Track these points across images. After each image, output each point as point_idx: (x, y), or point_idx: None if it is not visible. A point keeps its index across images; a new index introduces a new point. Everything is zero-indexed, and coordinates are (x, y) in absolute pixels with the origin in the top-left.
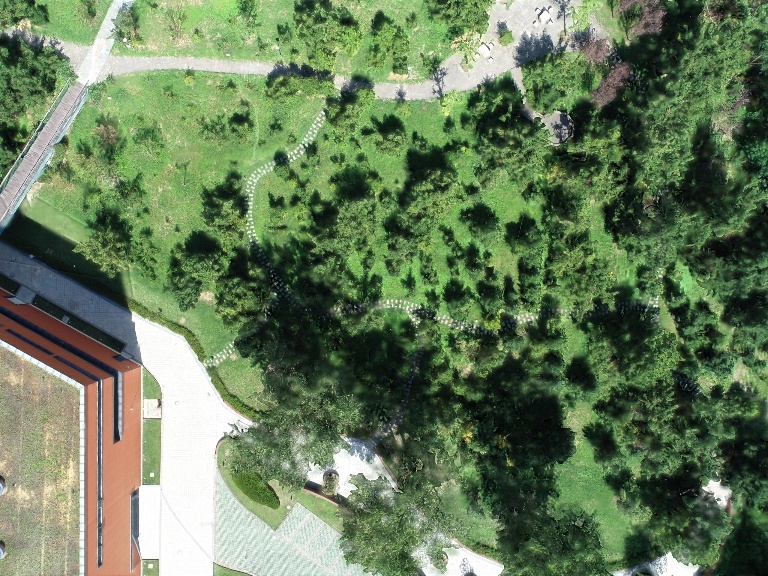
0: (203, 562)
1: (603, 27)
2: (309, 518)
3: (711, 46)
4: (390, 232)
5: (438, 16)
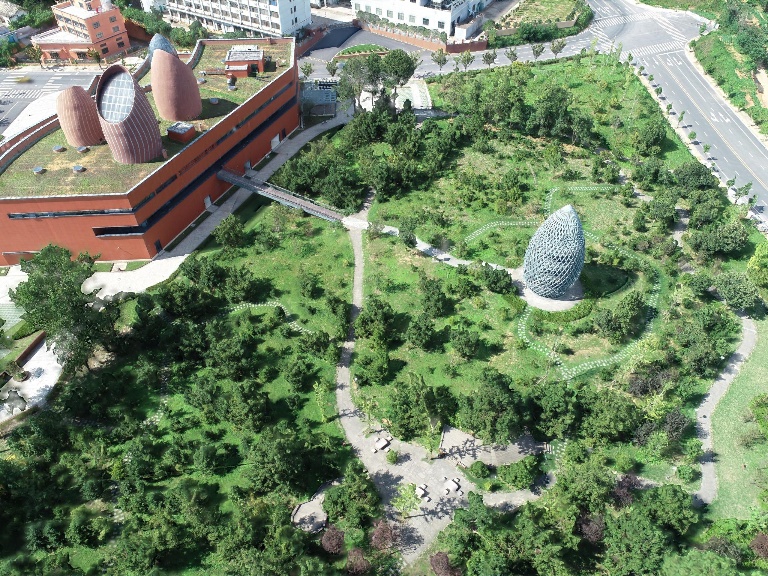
0: None
1: (419, 559)
2: None
3: None
4: None
5: None
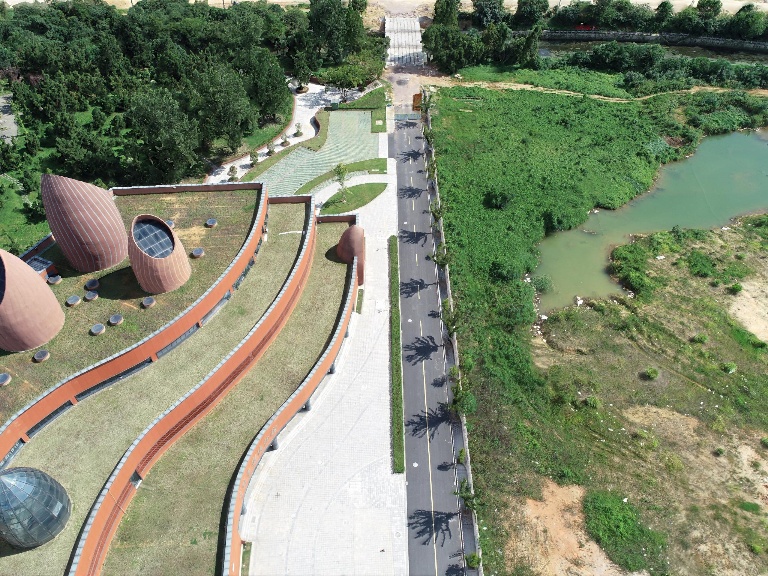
0: None
1: (9, 94)
2: None
3: (31, 48)
4: None
5: None
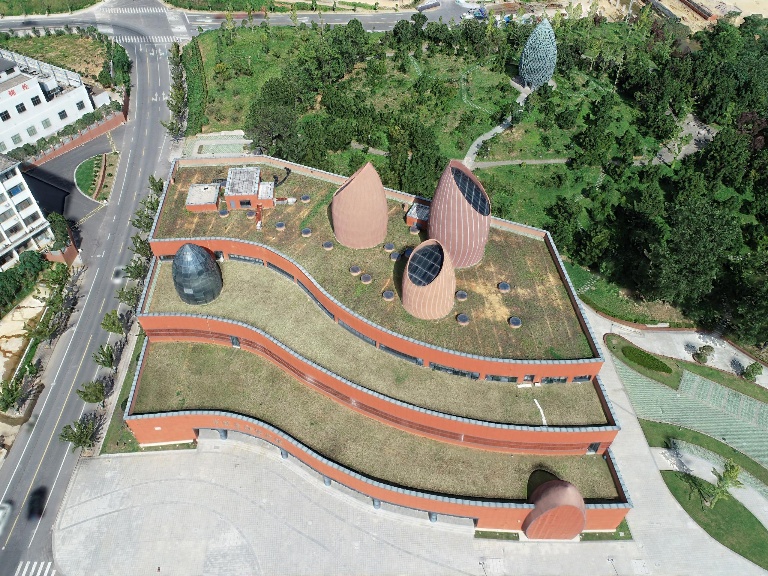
0: (628, 418)
1: None
2: (699, 380)
3: None
4: (666, 220)
5: (651, 130)
